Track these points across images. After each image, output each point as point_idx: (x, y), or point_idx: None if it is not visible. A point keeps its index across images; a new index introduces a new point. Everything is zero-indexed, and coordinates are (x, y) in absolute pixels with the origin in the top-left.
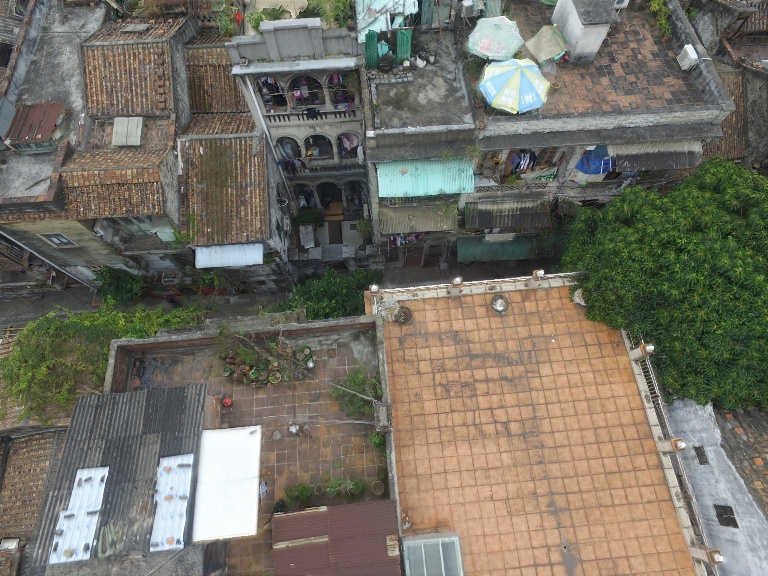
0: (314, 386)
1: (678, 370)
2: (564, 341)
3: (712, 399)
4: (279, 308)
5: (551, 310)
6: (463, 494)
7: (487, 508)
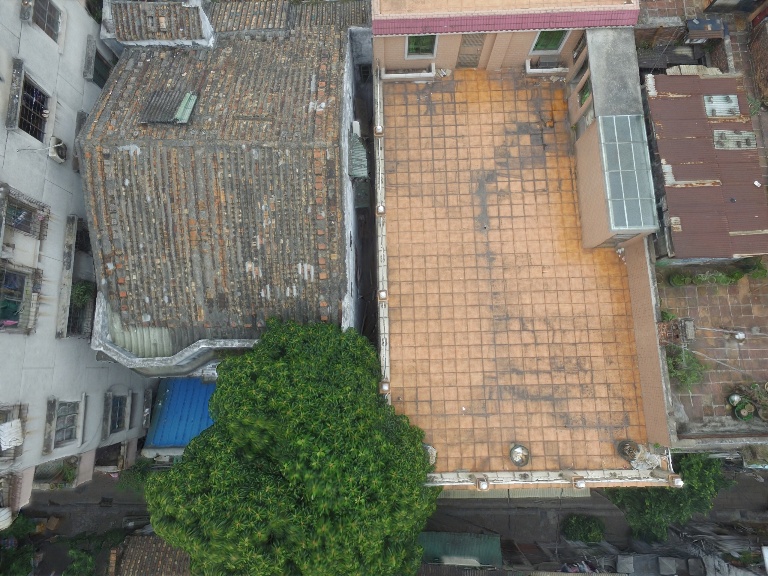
0: (724, 377)
1: (365, 363)
2: (453, 408)
3: None
4: (718, 488)
5: (460, 444)
6: (569, 272)
7: (548, 260)
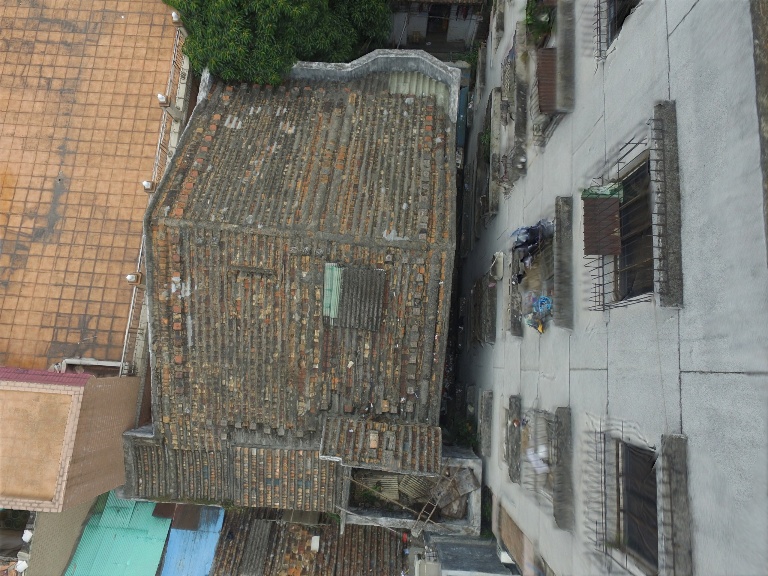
0: None
1: (190, 38)
2: (132, 18)
3: (208, 66)
4: None
5: None
6: None
7: (6, 142)
